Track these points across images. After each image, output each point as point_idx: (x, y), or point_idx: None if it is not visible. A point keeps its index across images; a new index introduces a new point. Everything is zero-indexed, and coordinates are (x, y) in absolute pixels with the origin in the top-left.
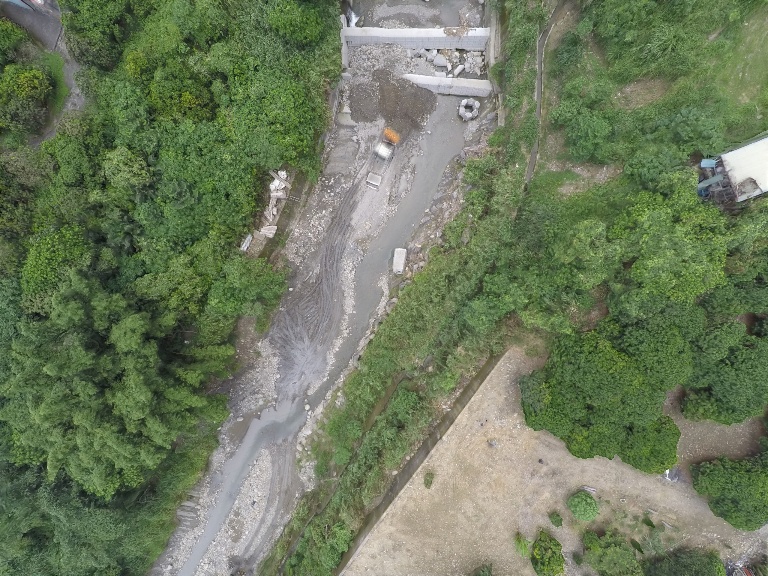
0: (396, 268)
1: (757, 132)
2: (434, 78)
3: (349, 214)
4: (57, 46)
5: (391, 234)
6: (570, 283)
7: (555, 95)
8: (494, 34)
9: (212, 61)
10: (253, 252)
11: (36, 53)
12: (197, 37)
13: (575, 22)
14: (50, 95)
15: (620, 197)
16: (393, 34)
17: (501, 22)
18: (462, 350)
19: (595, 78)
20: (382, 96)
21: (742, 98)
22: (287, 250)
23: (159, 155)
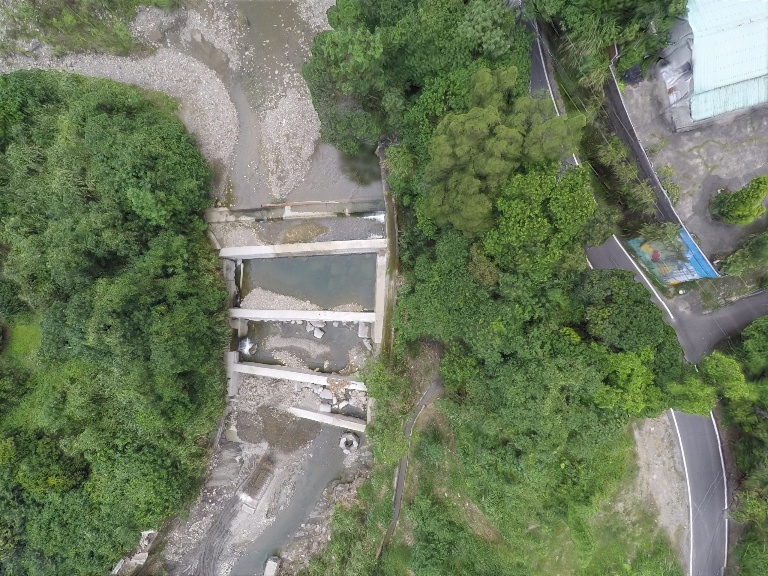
0: None
1: None
2: (317, 415)
3: (229, 521)
4: None
5: (268, 540)
6: None
7: (417, 475)
8: None
9: (81, 446)
10: (124, 573)
11: None
12: None
13: None
14: None
15: None
16: (279, 375)
17: None
18: None
19: (448, 482)
20: (265, 428)
21: None
22: (166, 550)
23: None
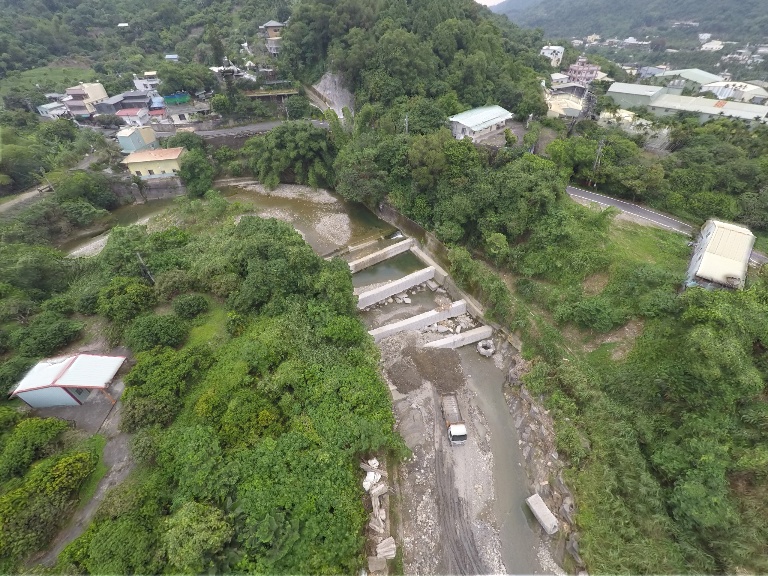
0: (549, 523)
1: (683, 270)
2: (447, 339)
3: (451, 486)
4: (101, 429)
5: (506, 487)
6: (741, 397)
7: (541, 311)
8: (469, 300)
9: (282, 377)
10: None
11: (82, 438)
12: (260, 367)
13: (513, 277)
14: (85, 483)
15: (670, 330)
16: (401, 324)
17: (469, 293)
18: (745, 574)
19: None
20: (418, 364)
21: (651, 262)
22: None
23: (239, 493)
